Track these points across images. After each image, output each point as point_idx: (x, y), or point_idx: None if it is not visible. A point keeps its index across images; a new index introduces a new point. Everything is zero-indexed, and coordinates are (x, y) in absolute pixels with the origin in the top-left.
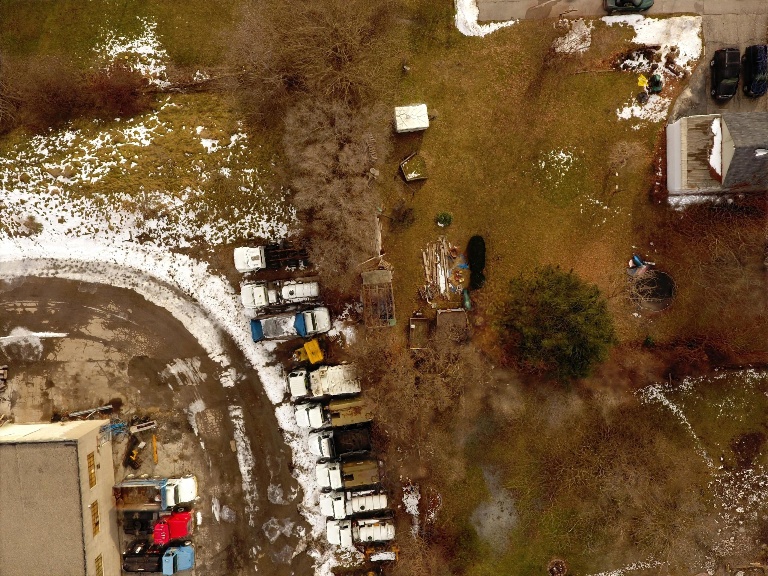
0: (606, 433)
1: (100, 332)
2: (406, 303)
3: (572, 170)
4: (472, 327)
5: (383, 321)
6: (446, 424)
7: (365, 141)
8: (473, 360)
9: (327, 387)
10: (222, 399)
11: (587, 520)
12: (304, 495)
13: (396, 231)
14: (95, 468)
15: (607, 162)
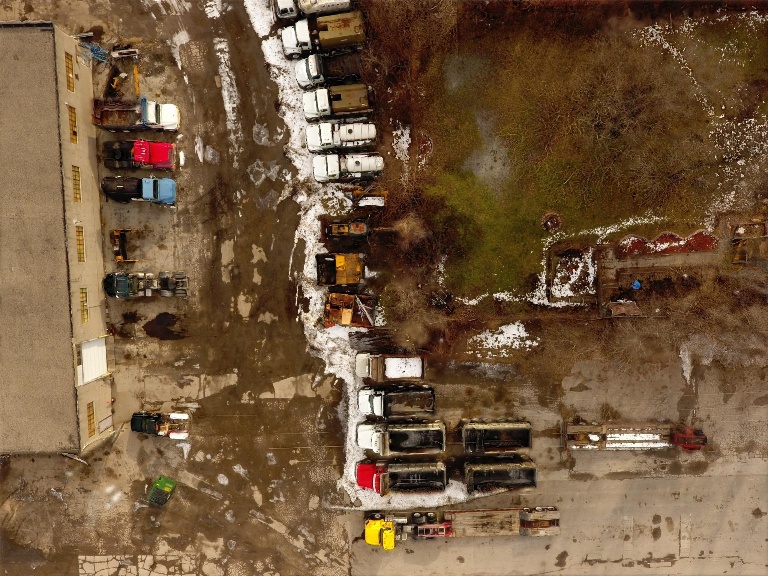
0: (604, 77)
1: None
2: None
3: None
4: None
5: None
6: (438, 65)
7: None
8: None
9: None
10: (207, 31)
11: (583, 171)
12: (290, 136)
13: None
14: (73, 75)
15: None
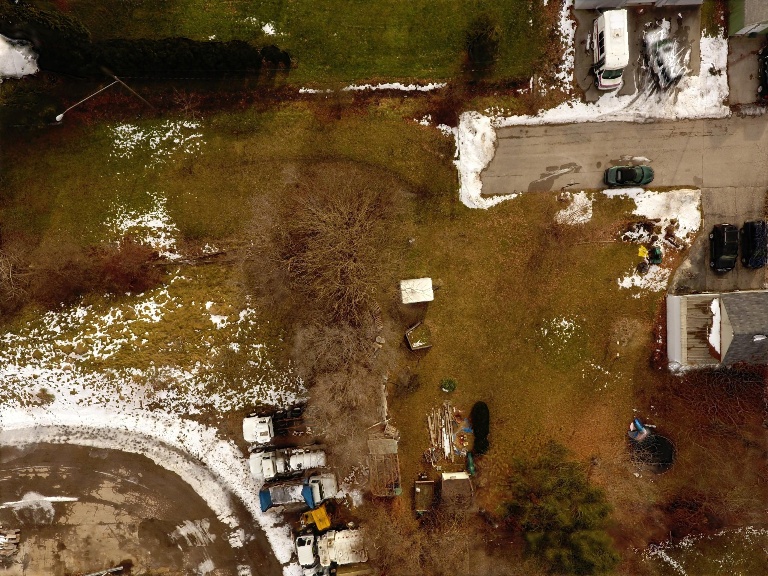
0: None
1: (111, 496)
2: (411, 465)
3: (574, 337)
4: (476, 490)
5: (389, 490)
6: None
7: (371, 313)
8: (477, 520)
9: (334, 557)
10: (231, 559)
11: None
12: None
13: (401, 396)
14: None
15: (608, 329)
